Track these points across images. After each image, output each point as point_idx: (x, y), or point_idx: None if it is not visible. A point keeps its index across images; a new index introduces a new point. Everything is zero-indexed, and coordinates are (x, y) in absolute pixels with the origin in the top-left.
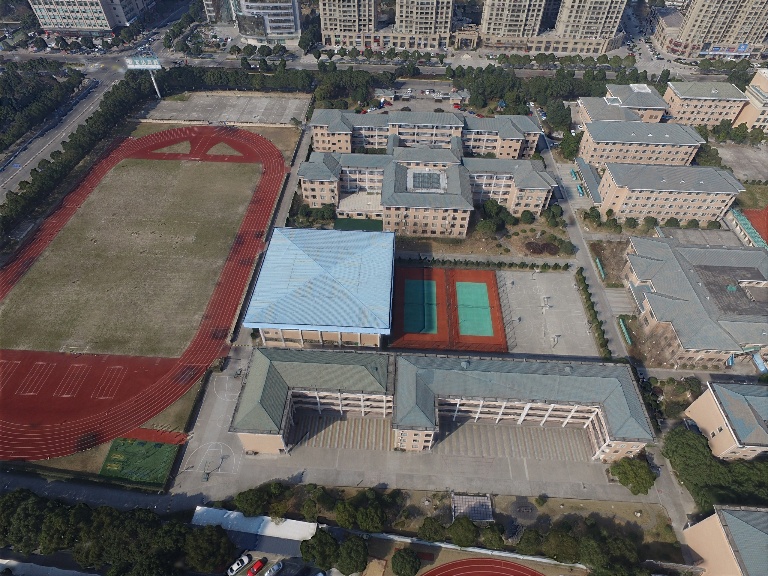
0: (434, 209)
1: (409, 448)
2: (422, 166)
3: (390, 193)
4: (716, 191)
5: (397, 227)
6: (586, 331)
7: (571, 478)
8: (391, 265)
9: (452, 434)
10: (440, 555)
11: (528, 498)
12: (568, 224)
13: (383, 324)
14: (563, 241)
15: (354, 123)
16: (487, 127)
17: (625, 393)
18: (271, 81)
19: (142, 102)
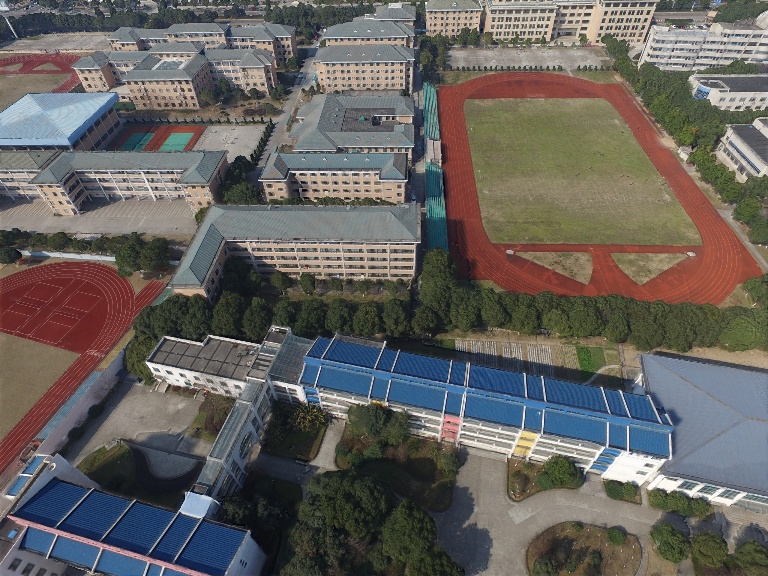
0: (163, 82)
1: (64, 213)
2: (172, 57)
3: (130, 71)
4: (389, 60)
5: (144, 101)
6: (249, 155)
7: (170, 225)
8: (98, 109)
9: (103, 207)
10: (47, 260)
11: (131, 234)
12: (289, 99)
13: (64, 136)
14: (276, 108)
15: (141, 36)
16: (247, 34)
17: (204, 160)
18: (108, 21)
19: (1, 42)
